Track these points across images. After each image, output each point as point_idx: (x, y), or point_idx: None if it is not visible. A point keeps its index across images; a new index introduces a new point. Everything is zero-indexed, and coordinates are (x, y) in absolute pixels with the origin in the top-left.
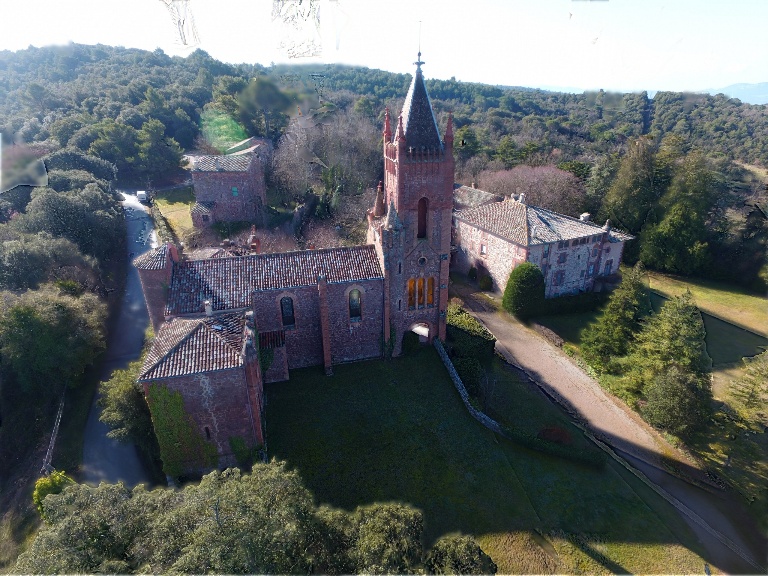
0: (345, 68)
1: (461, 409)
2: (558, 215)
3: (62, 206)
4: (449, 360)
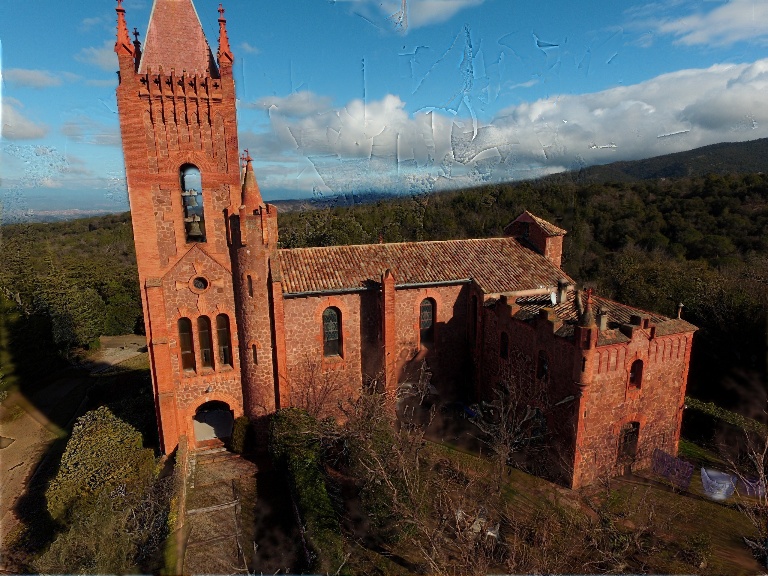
0: None
1: None
2: None
3: None
4: None
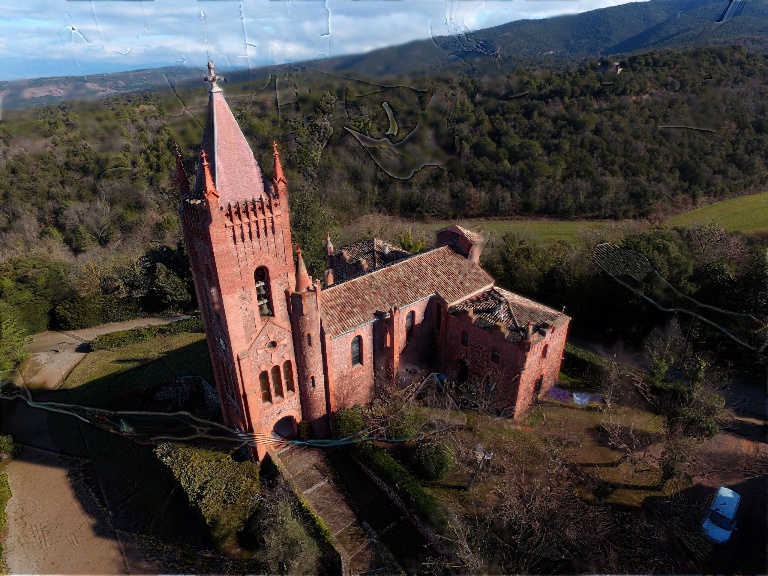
0: (396, 79)
1: (209, 383)
2: None
3: None
4: None
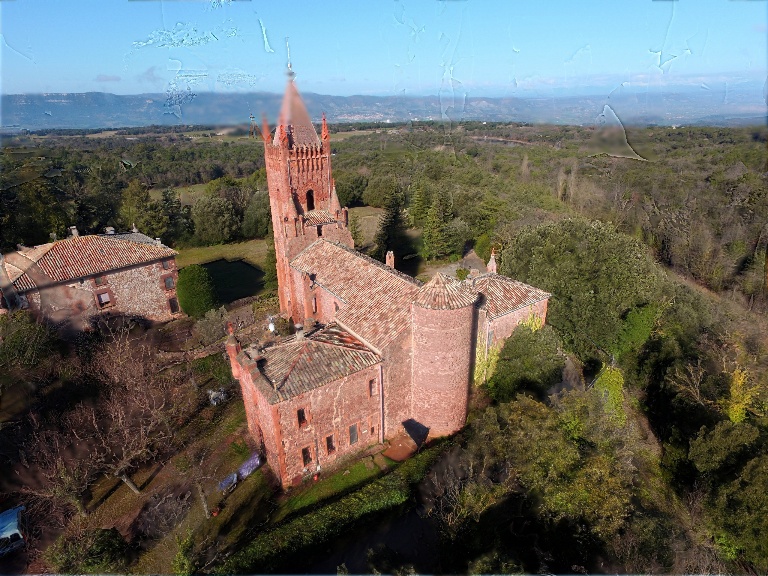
0: None
1: None
2: (108, 235)
3: None
4: None
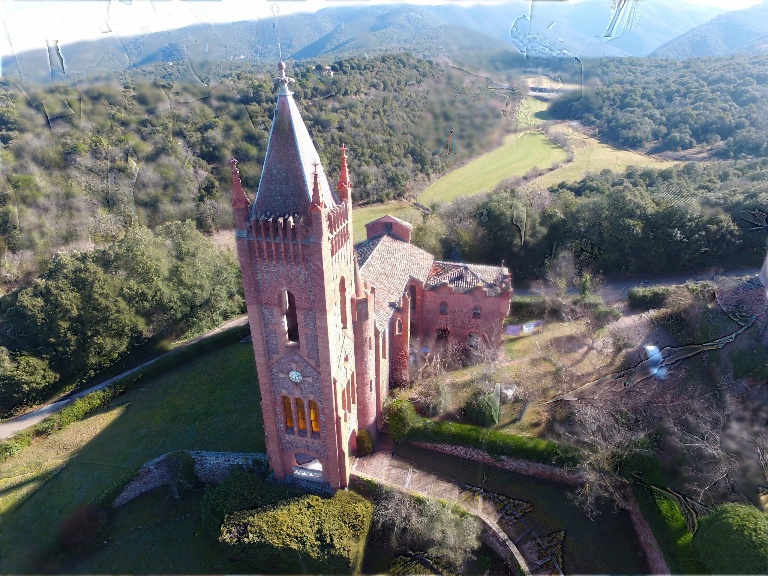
0: None
1: None
2: None
3: (615, 202)
4: (237, 455)
